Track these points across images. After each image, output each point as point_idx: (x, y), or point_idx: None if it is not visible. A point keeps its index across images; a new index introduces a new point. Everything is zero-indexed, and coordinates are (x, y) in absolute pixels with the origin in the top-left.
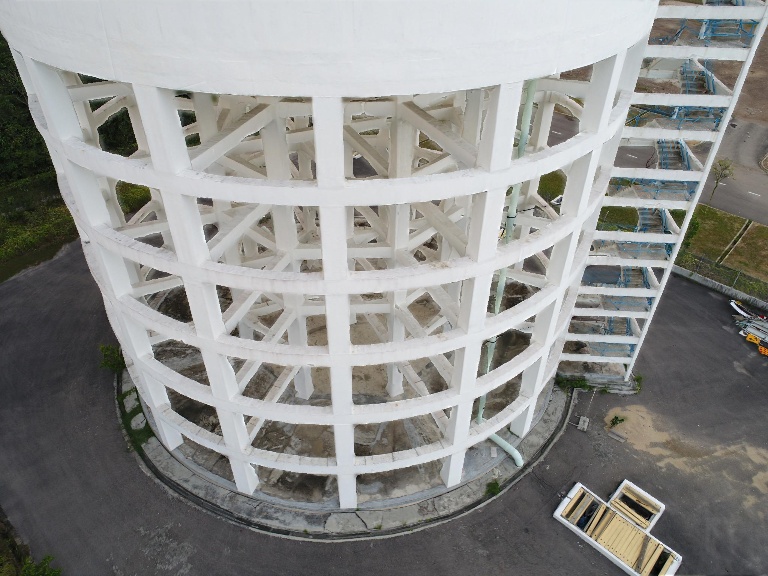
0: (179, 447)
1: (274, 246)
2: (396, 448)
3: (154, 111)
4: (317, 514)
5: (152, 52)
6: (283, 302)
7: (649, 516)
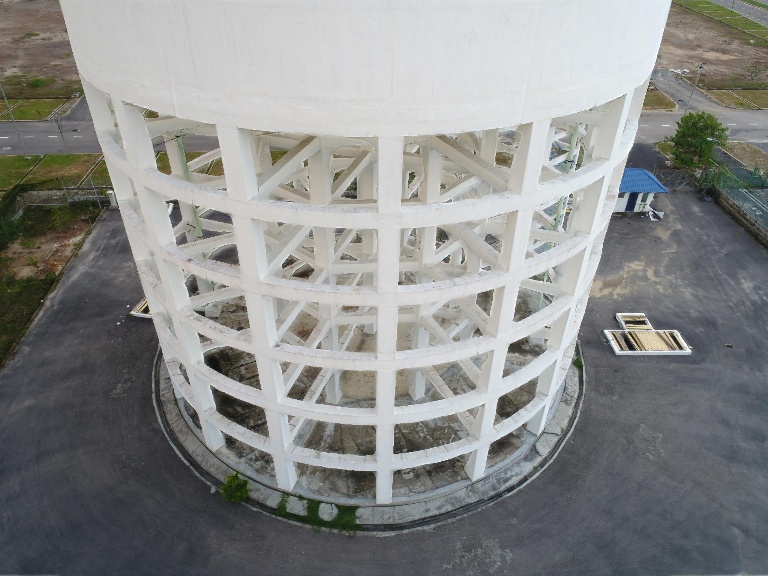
0: (392, 495)
1: (413, 265)
2: None
3: (542, 140)
4: (527, 453)
5: (559, 90)
6: (418, 313)
7: (644, 323)
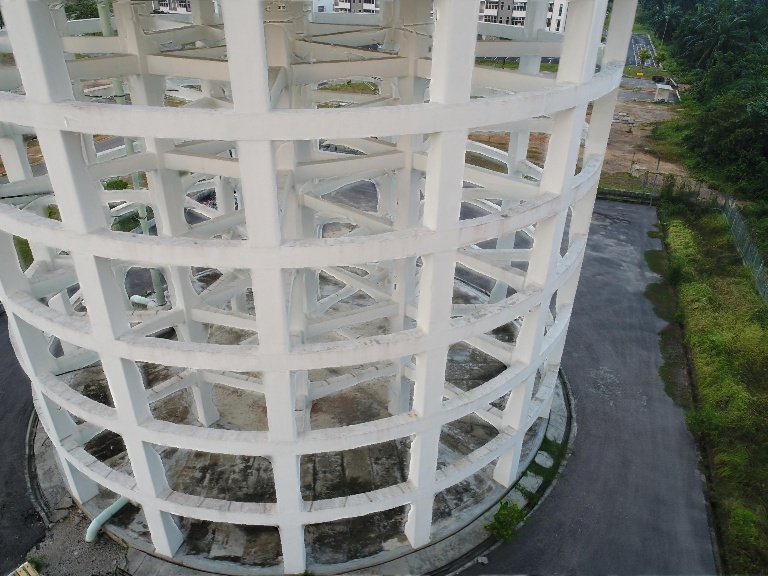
0: None
1: None
2: None
3: None
4: None
5: None
6: None
7: None
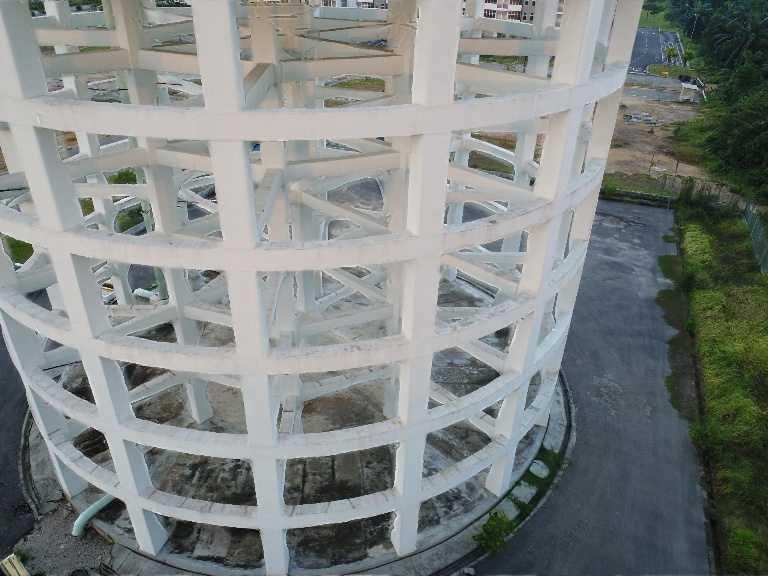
0: None
1: None
2: (442, 302)
3: None
4: None
5: None
6: None
7: None
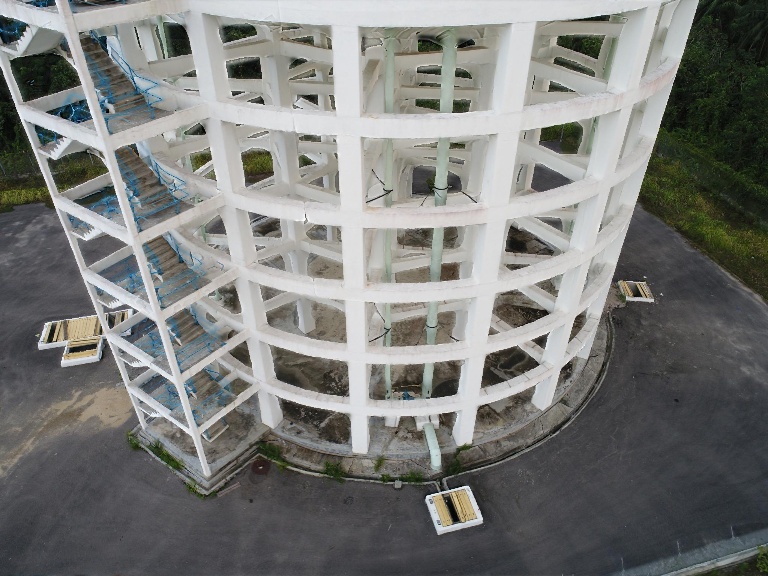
0: None
1: None
2: None
3: None
4: None
5: None
6: None
7: None
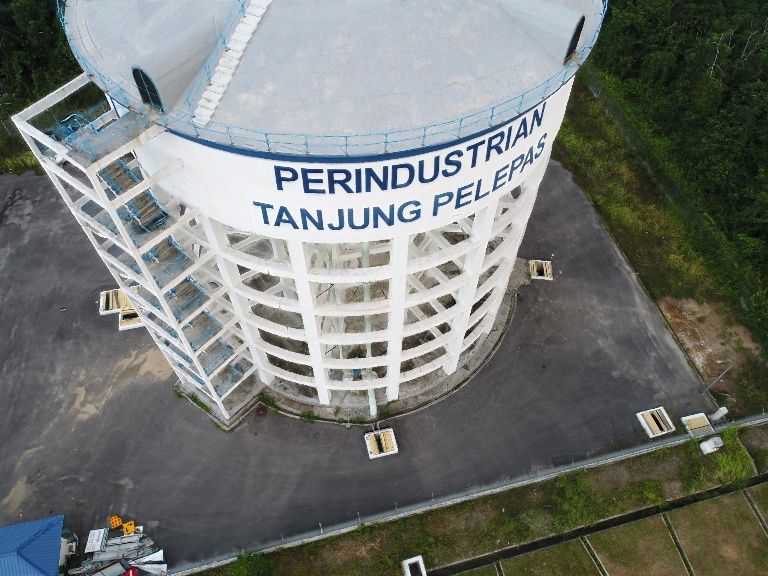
0: None
1: None
2: None
3: None
4: None
5: None
6: None
7: None
